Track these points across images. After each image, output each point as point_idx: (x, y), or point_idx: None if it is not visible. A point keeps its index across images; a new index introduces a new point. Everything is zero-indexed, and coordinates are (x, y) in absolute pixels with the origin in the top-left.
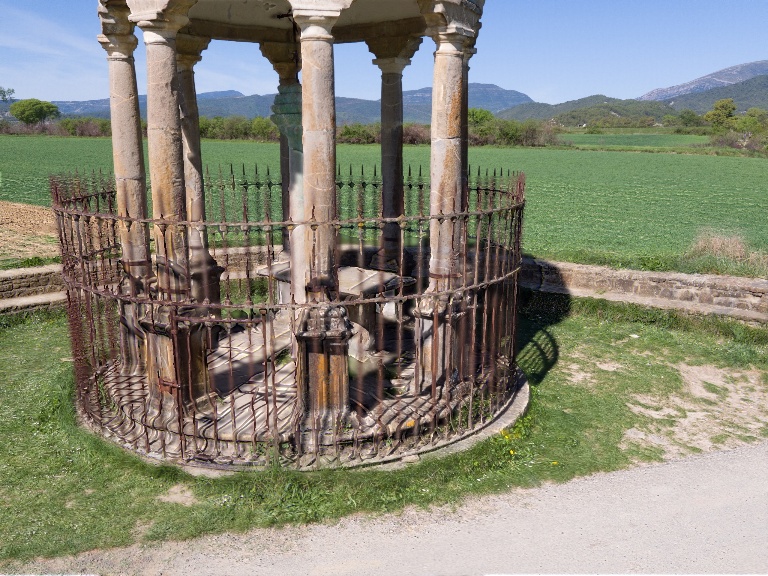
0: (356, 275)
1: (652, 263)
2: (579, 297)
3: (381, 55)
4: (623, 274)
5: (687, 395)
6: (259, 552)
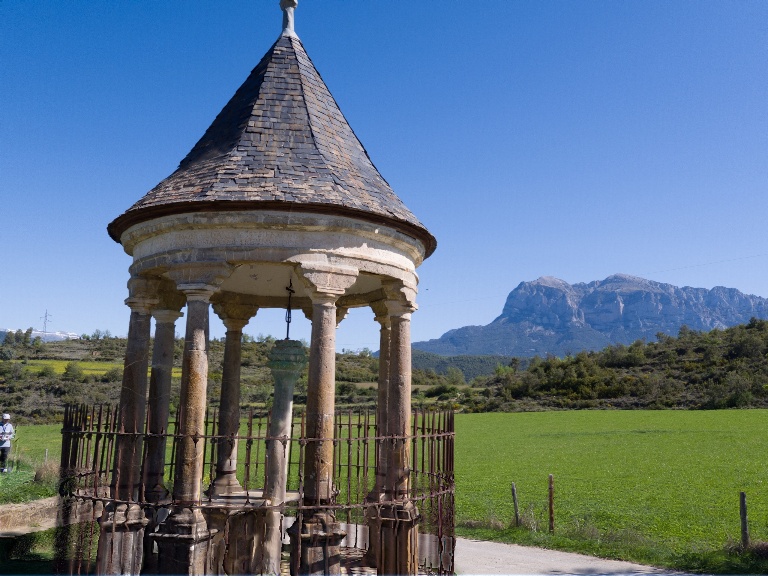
0: (257, 493)
1: (45, 491)
2: (45, 531)
3: (170, 307)
4: (51, 503)
5: None
6: None
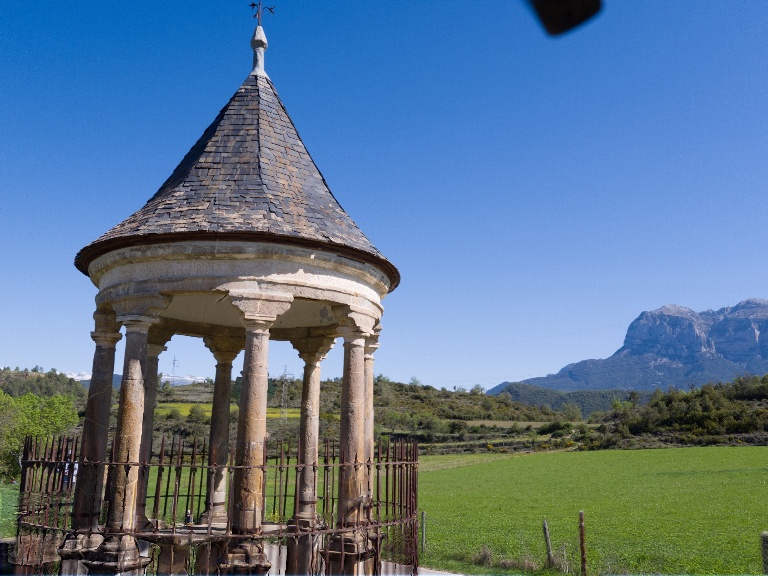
0: None
1: None
2: None
3: None
4: None
5: None
6: None
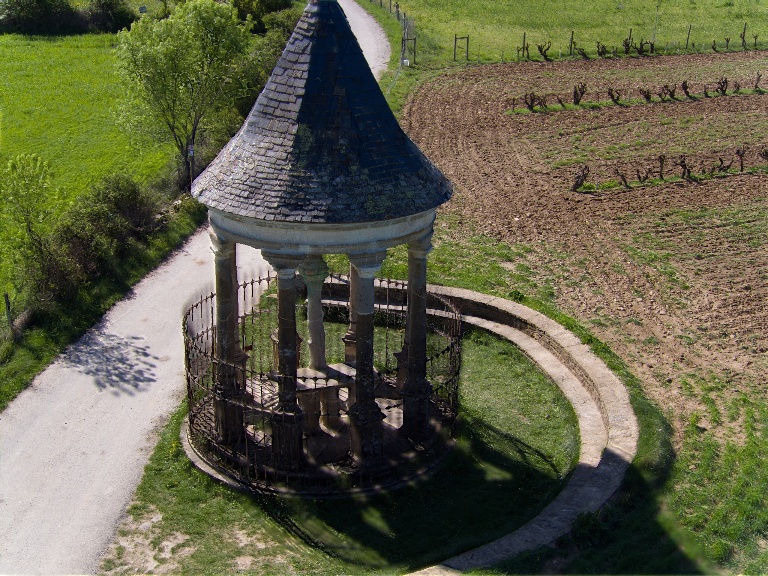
0: None
1: None
2: None
3: None
4: None
5: (173, 575)
6: None
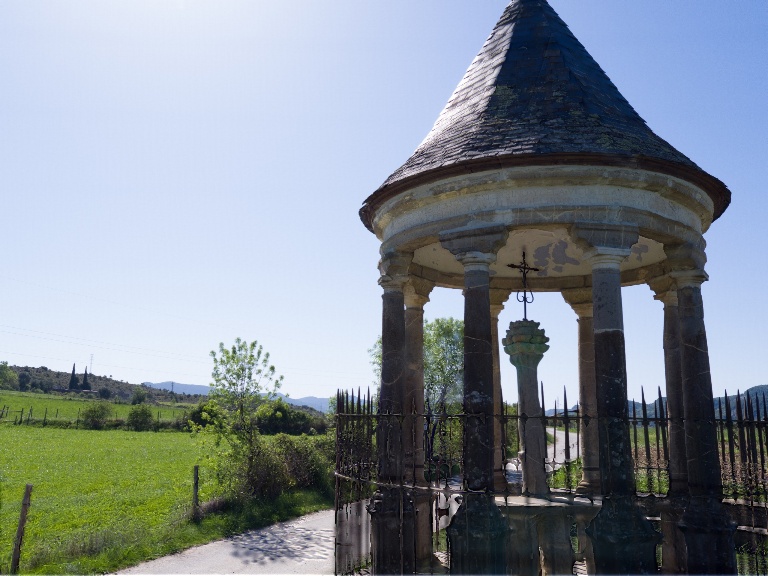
0: (520, 501)
1: None
2: None
3: None
4: None
5: None
6: (348, 567)
